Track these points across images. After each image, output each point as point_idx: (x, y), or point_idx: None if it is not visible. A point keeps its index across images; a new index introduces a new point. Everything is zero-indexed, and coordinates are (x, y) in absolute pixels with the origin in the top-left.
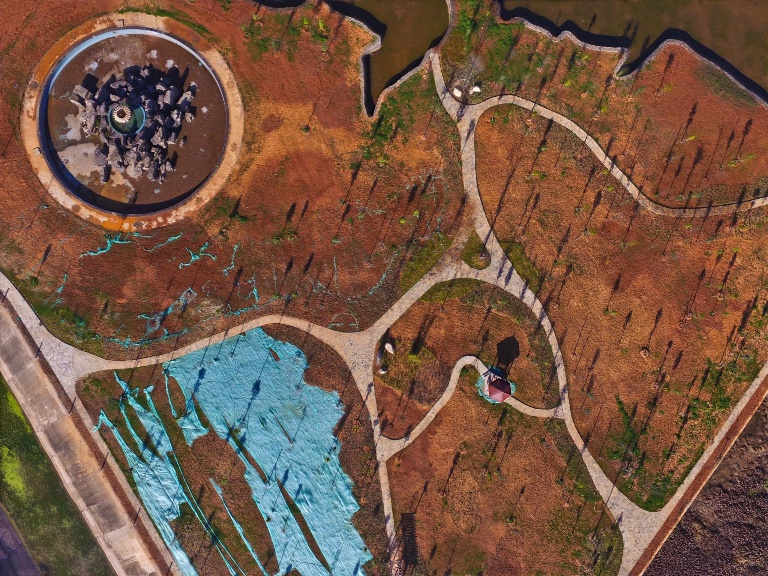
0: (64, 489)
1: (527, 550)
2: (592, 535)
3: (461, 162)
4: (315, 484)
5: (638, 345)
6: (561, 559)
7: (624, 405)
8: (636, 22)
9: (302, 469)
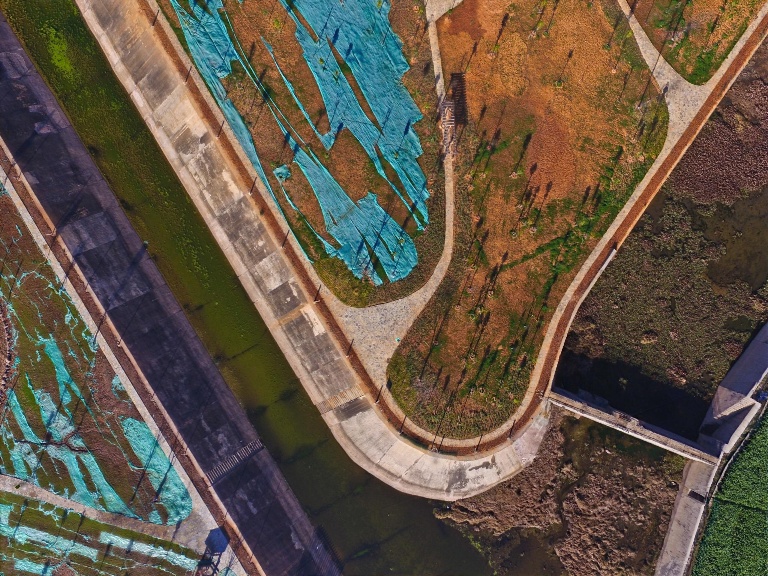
0: (112, 72)
1: (575, 115)
2: (638, 104)
3: None
4: (365, 44)
5: None
6: (608, 127)
7: None
8: None
9: (352, 29)
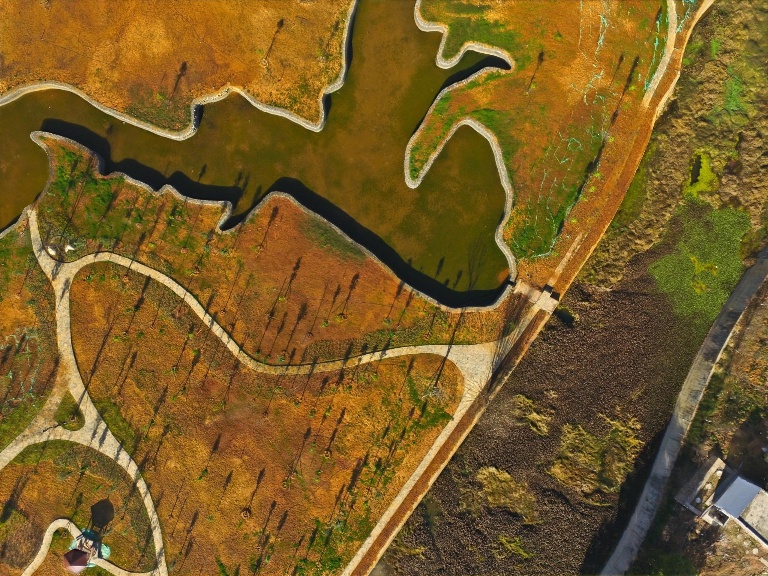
0: None
1: None
2: None
3: (56, 321)
4: None
5: (239, 506)
6: None
7: (226, 567)
8: (247, 171)
9: None
